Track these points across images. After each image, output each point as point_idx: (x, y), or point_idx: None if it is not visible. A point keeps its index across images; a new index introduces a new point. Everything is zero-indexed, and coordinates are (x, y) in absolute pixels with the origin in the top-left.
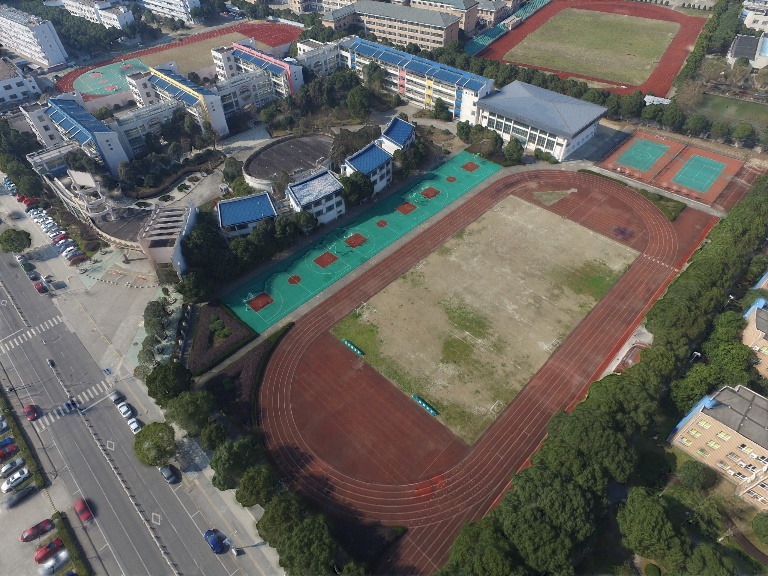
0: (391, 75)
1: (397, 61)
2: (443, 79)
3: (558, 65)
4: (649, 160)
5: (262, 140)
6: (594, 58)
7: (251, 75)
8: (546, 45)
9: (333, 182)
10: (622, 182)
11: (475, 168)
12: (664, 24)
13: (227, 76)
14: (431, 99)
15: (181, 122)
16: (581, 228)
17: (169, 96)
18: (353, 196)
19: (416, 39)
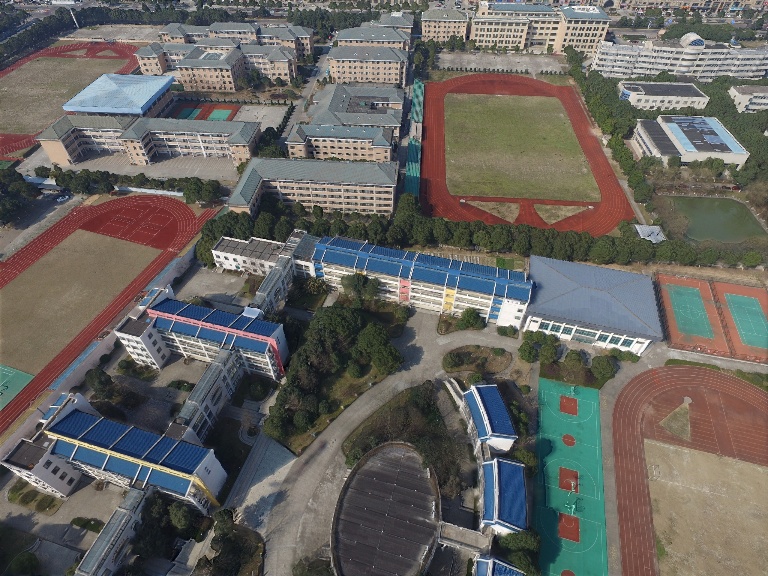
0: (385, 284)
1: (394, 271)
2: (473, 290)
3: (510, 189)
4: (702, 318)
5: (286, 468)
6: (532, 169)
7: (219, 369)
8: (474, 159)
9: (510, 575)
10: (715, 367)
11: (575, 406)
12: (546, 102)
13: (152, 356)
14: (452, 306)
15: (164, 520)
16: (747, 466)
17: (110, 473)
18: (537, 575)
19: (355, 198)
